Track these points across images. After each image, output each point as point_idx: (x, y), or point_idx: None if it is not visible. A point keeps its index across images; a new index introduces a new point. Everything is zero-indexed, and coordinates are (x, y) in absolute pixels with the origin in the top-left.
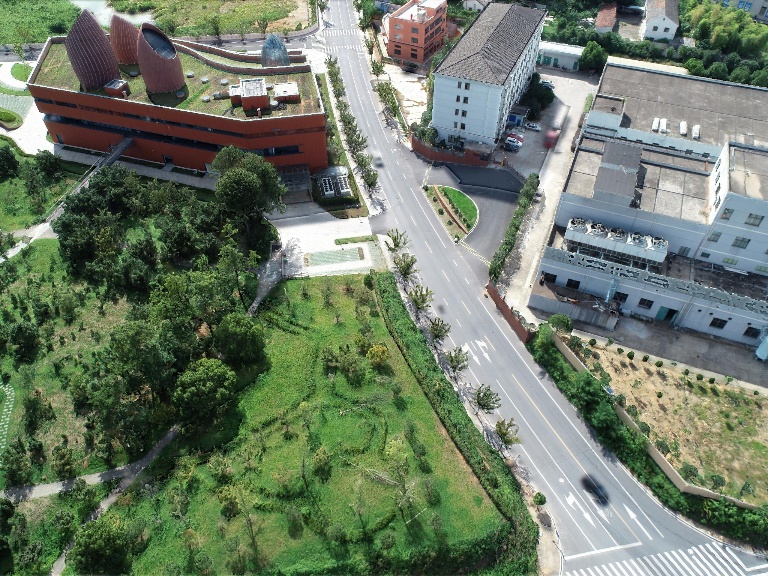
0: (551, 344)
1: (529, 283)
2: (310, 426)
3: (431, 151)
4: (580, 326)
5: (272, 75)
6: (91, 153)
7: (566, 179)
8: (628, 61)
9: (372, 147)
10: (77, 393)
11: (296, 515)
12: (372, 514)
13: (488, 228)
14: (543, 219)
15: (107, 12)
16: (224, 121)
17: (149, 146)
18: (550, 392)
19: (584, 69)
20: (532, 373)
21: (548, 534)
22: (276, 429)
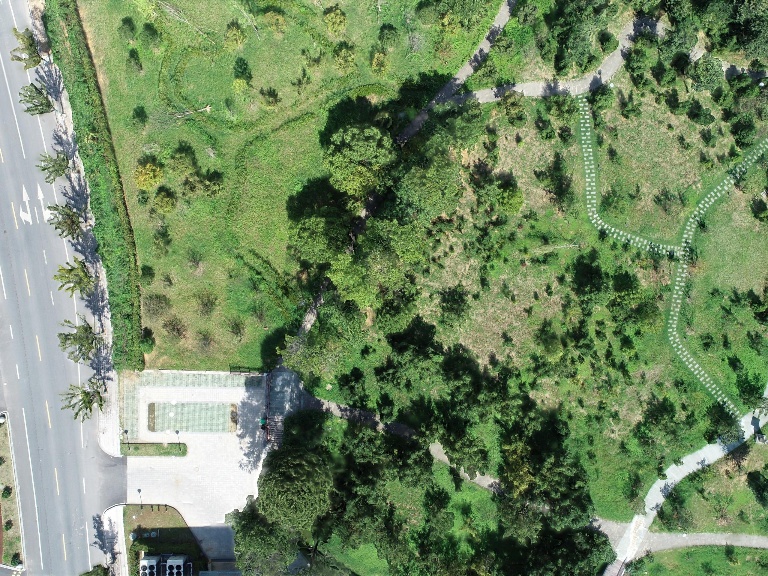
0: None
1: None
2: None
3: None
4: None
5: None
6: None
7: None
8: None
9: None
10: None
11: None
12: None
13: None
14: None
15: None
16: None
17: None
18: None
19: None
20: None
21: None
22: (286, 109)
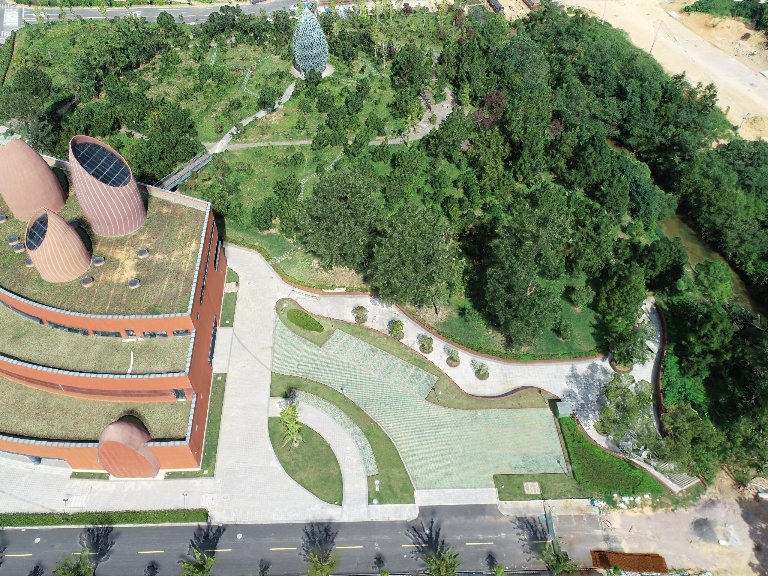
0: None
1: None
2: None
3: None
4: None
5: None
6: None
7: None
8: None
9: None
10: None
11: None
12: None
13: None
14: None
15: None
16: None
17: None
18: None
19: None
20: None
21: (4, 42)
22: None
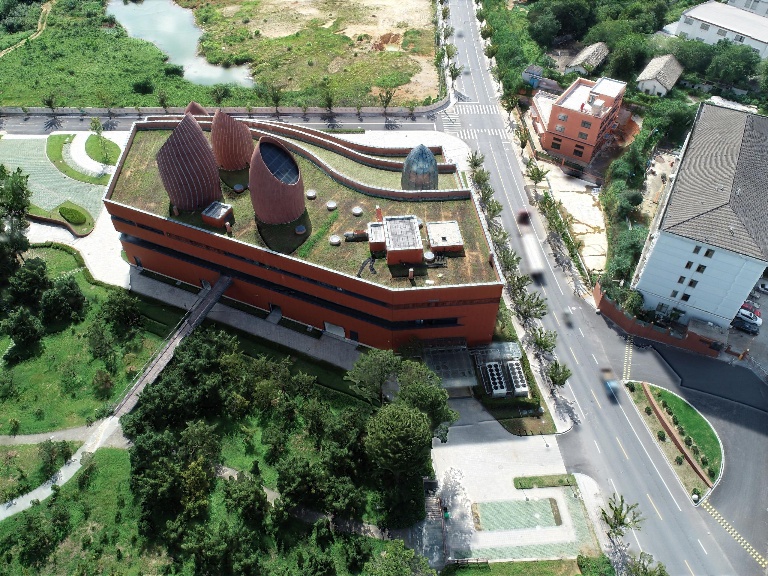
0: None
1: None
2: None
3: (632, 323)
4: None
5: (419, 201)
6: (176, 284)
7: None
8: None
9: None
10: None
11: None
12: None
13: (742, 481)
14: None
15: (198, 63)
16: (363, 285)
17: (252, 290)
18: None
19: None
20: None
21: None
22: None
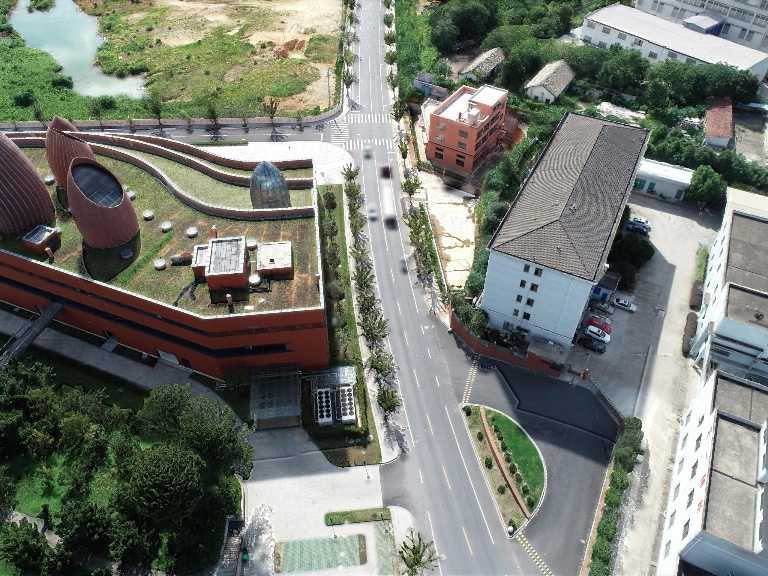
0: None
1: None
2: None
3: (478, 343)
4: None
5: (260, 221)
6: (13, 311)
7: (706, 496)
8: (757, 199)
9: (395, 320)
10: None
11: None
12: None
13: (561, 510)
14: (648, 501)
15: (92, 74)
16: (177, 313)
17: (84, 317)
18: None
19: (691, 200)
20: None
21: None
22: None
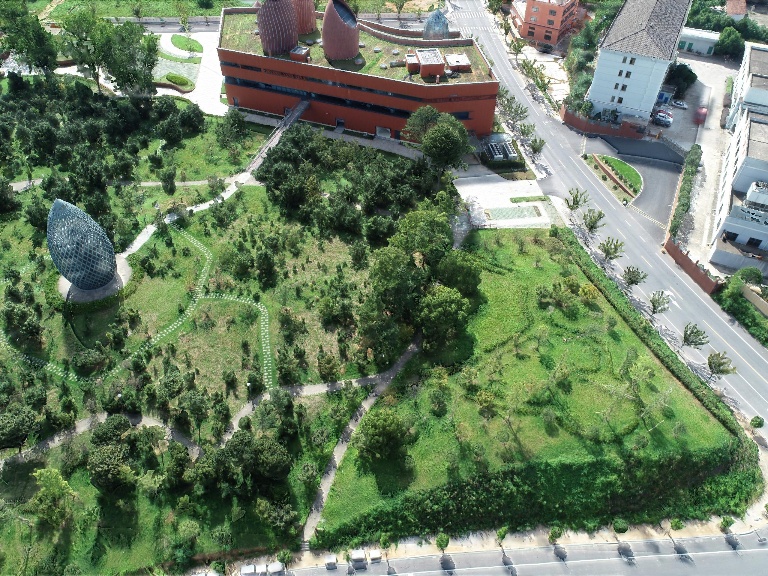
0: (739, 295)
1: (706, 242)
2: (539, 349)
3: (586, 123)
4: (763, 281)
5: (437, 47)
6: (265, 115)
7: (747, 146)
8: (766, 46)
9: (524, 119)
10: (325, 312)
11: (553, 417)
12: (618, 421)
13: (654, 193)
14: (707, 187)
15: None
16: (407, 86)
17: (324, 109)
18: (743, 337)
19: (719, 54)
20: (722, 320)
21: (766, 453)
22: (507, 351)
